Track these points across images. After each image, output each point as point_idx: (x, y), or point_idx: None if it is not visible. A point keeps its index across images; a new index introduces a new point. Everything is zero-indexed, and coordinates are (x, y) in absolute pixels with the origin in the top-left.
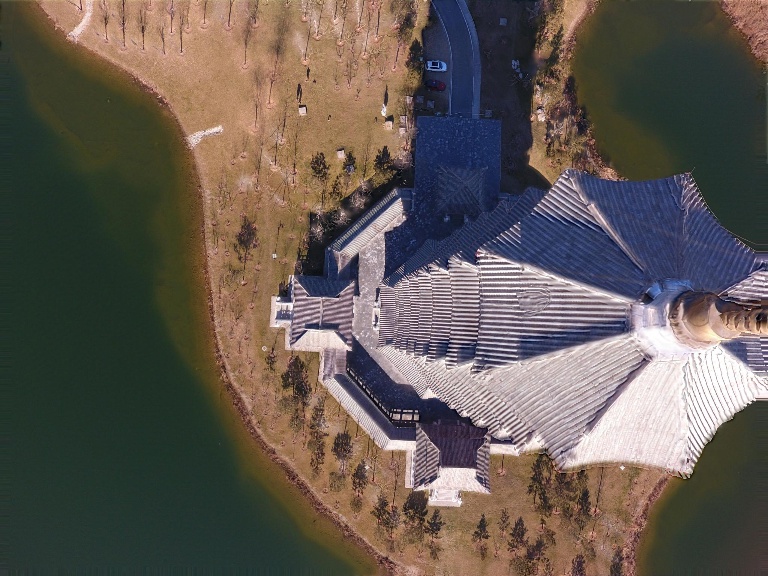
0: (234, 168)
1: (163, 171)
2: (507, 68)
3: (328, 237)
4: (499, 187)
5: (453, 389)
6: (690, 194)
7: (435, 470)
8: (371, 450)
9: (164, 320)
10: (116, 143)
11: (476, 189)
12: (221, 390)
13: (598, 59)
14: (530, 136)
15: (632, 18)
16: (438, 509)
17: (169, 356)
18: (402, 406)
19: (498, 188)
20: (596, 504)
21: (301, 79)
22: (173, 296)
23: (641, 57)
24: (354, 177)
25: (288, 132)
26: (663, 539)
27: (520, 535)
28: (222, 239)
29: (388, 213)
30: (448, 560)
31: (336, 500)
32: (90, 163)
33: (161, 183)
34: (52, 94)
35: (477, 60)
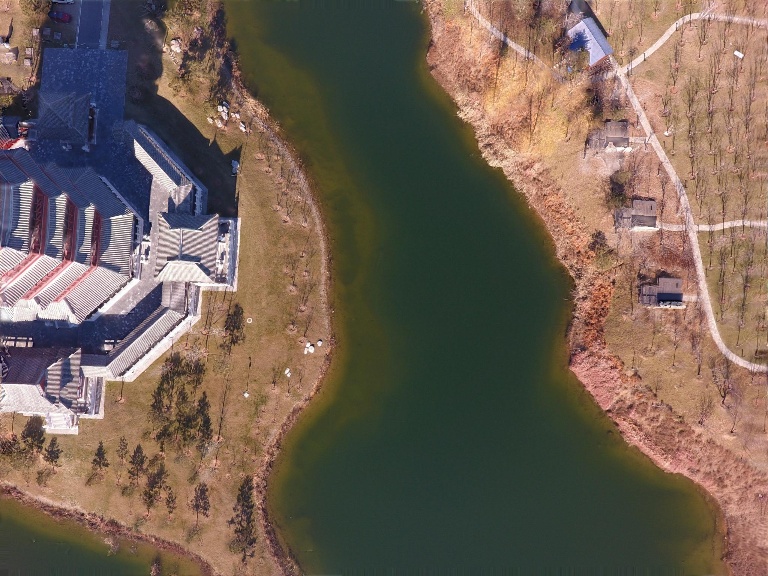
0: None
1: None
2: None
3: None
4: (122, 116)
5: None
6: None
7: None
8: None
9: None
10: None
11: (65, 112)
12: None
13: None
14: (160, 66)
15: None
16: (55, 437)
17: None
18: (16, 334)
19: (121, 117)
20: (219, 432)
21: None
22: None
23: None
24: None
25: None
26: (301, 469)
27: (140, 463)
28: None
29: None
30: (72, 489)
31: None
32: None
33: None
34: None
35: None
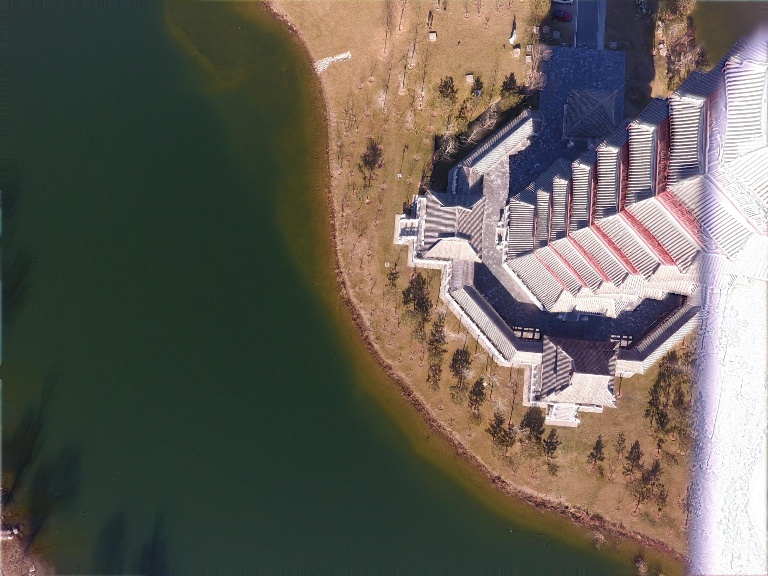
0: (361, 92)
1: (289, 95)
2: (631, 3)
3: (452, 159)
4: (622, 116)
5: (662, 237)
6: None
7: (566, 378)
8: (490, 367)
9: (286, 237)
10: (245, 67)
11: (609, 110)
12: (340, 306)
13: (715, 2)
14: (653, 69)
15: None
16: (555, 428)
17: (289, 272)
18: (523, 324)
19: (621, 117)
20: (712, 432)
21: (432, 7)
22: (295, 215)
23: (758, 1)
24: (480, 102)
25: (418, 57)
26: None
27: (636, 459)
28: (347, 160)
29: (518, 133)
30: (561, 481)
31: (451, 417)
32: (220, 85)
33: (287, 106)
34: (186, 20)
35: None
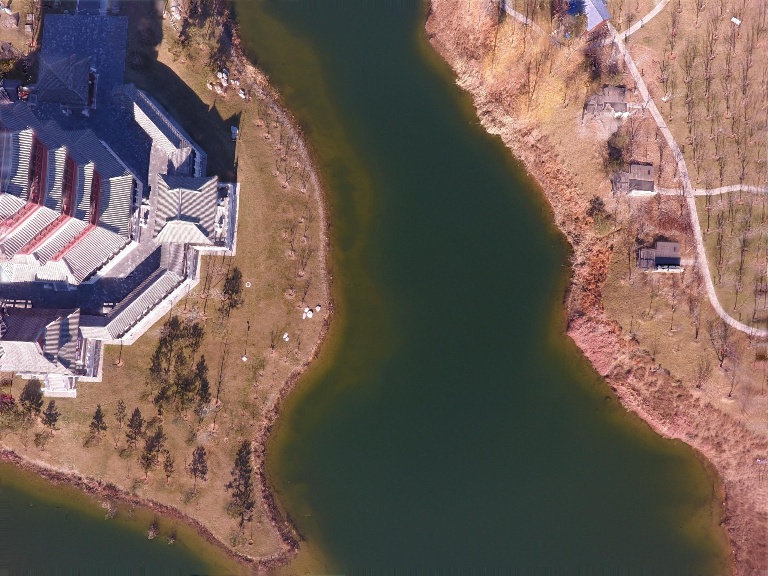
0: None
1: None
2: None
3: None
4: (122, 81)
5: None
6: None
7: None
8: None
9: None
10: None
11: (65, 74)
12: None
13: None
14: (160, 32)
15: None
16: (54, 400)
17: None
18: (15, 296)
19: (121, 82)
20: (217, 395)
21: None
22: None
23: None
24: None
25: None
26: (299, 435)
27: (138, 426)
28: None
29: None
30: (70, 453)
31: None
32: None
33: None
34: None
35: None
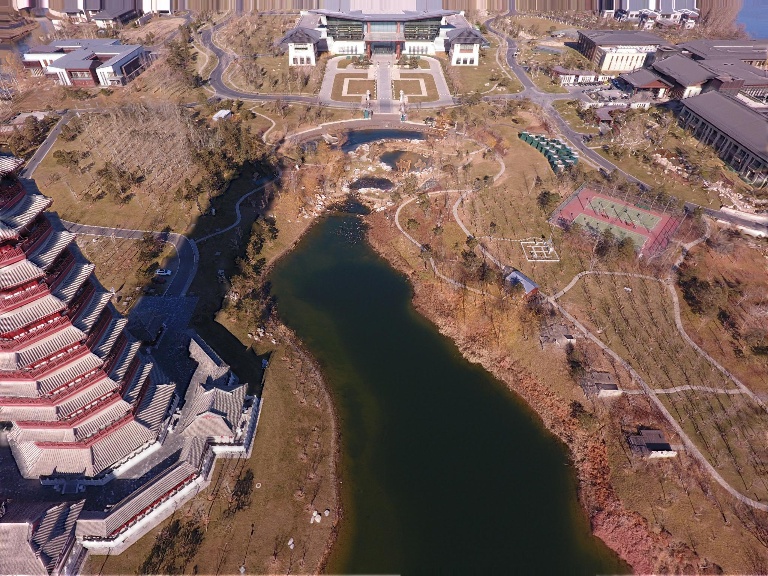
0: None
1: None
2: (214, 273)
3: None
4: None
5: None
6: (1, 144)
7: None
8: None
9: None
10: None
11: (147, 320)
12: None
13: (291, 275)
14: (220, 305)
15: (317, 257)
16: None
17: None
18: None
19: None
20: None
21: None
22: None
23: (320, 273)
24: None
25: None
26: None
27: None
28: None
29: None
30: None
31: None
32: None
33: None
34: None
35: (195, 270)
